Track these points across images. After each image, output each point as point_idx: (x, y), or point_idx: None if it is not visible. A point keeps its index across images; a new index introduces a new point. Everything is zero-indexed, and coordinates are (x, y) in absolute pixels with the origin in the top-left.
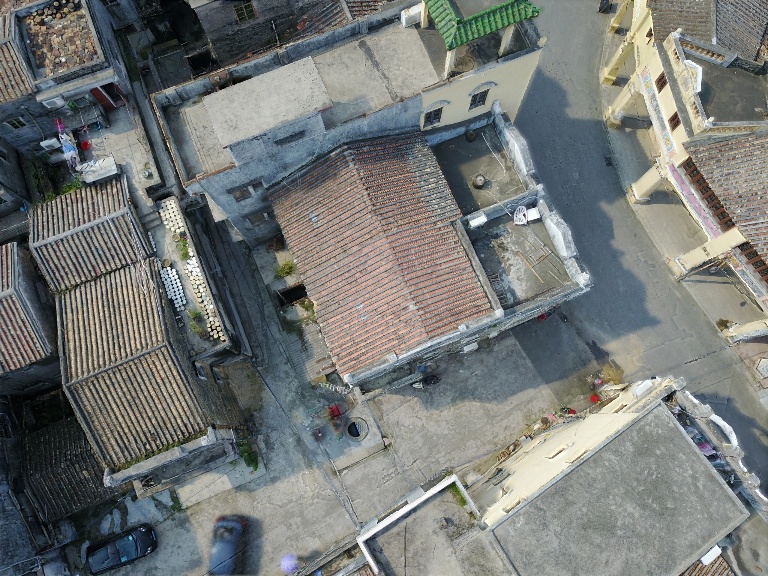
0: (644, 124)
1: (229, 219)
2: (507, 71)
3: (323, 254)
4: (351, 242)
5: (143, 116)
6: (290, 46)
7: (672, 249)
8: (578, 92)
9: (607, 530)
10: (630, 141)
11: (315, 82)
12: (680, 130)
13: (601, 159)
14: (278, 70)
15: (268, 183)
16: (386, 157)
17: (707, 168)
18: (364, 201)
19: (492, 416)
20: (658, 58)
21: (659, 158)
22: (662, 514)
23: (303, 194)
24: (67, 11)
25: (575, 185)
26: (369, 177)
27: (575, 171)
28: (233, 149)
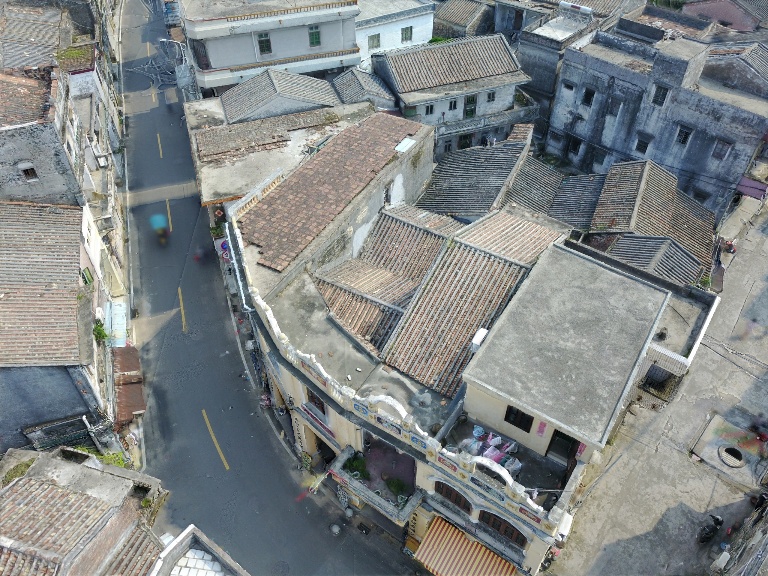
0: None
1: None
2: None
3: None
4: None
5: None
6: None
7: None
8: None
9: (578, 323)
10: None
11: None
12: None
13: None
14: None
15: None
16: None
17: None
18: None
19: (616, 526)
20: None
21: None
22: (540, 350)
23: None
24: None
25: None
26: None
27: None
28: None
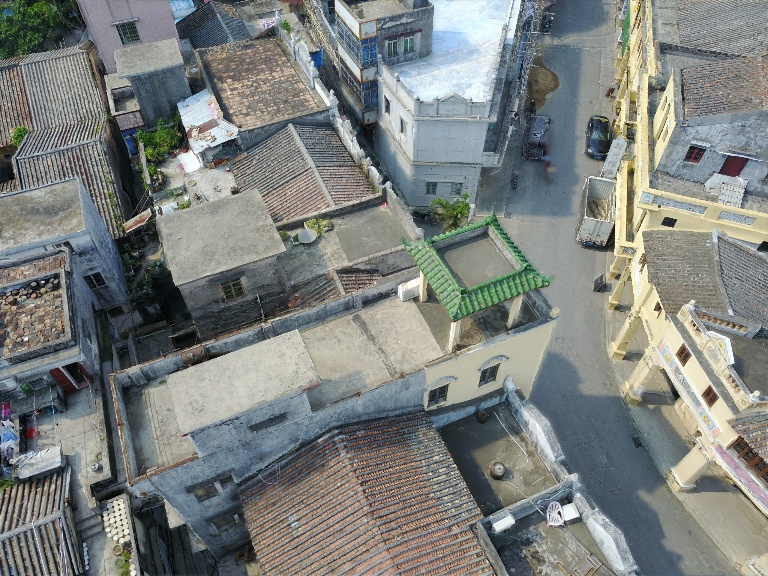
0: (667, 400)
1: (188, 524)
2: (519, 344)
3: (304, 575)
4: (341, 557)
5: (107, 398)
6: (276, 321)
7: (739, 550)
8: (588, 367)
9: None
10: (656, 419)
11: (301, 357)
12: (720, 406)
13: (628, 439)
14: (259, 344)
15: (240, 477)
16: (385, 443)
17: (765, 450)
18: (358, 500)
19: None
20: (674, 330)
21: (700, 438)
22: None
23: (282, 491)
24: (44, 291)
25: (604, 470)
26: (364, 468)
27: (601, 454)
28: (195, 437)
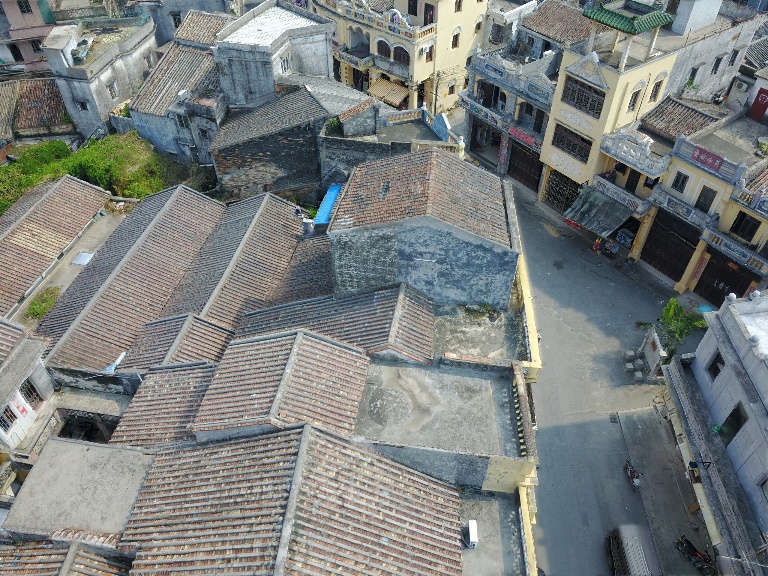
0: None
1: None
2: None
3: None
4: None
5: None
6: None
7: None
8: None
9: None
10: None
11: None
12: None
13: None
14: None
15: None
16: None
17: None
18: None
19: None
20: None
21: None
22: None
23: None
24: None
25: None
26: None
27: None
28: None
